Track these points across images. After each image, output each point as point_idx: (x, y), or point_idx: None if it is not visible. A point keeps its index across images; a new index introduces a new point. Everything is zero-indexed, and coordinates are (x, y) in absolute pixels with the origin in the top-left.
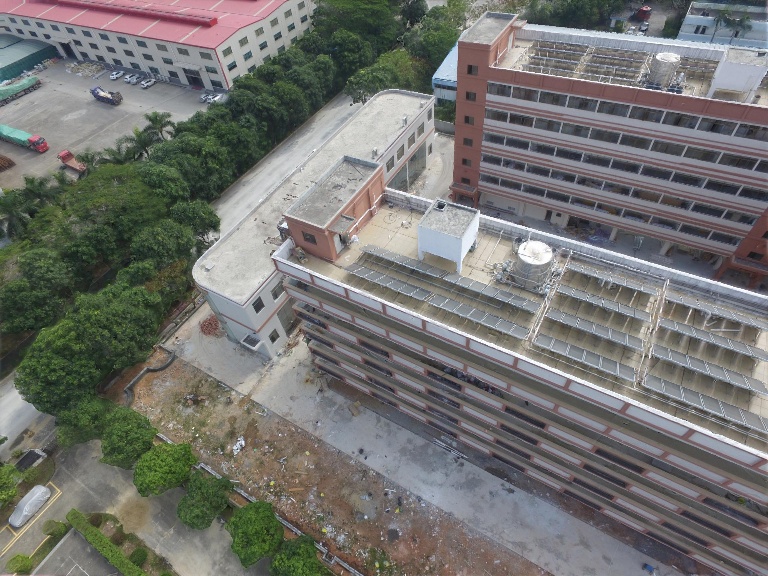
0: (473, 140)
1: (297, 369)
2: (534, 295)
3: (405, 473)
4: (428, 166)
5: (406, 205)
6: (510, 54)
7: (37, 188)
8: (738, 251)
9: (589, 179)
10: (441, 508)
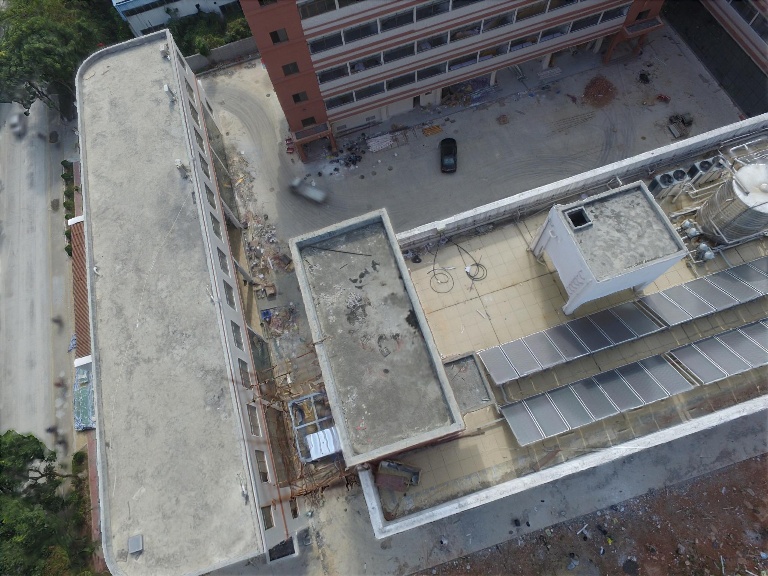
0: (297, 62)
1: (351, 508)
2: (757, 242)
3: (576, 498)
4: (221, 131)
5: (438, 240)
6: None
7: None
8: (627, 20)
9: (464, 28)
10: (638, 495)
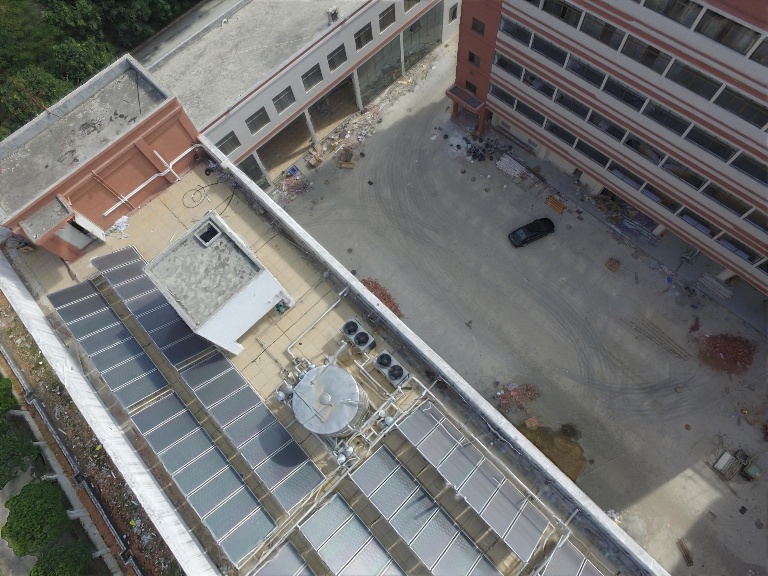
0: (486, 25)
1: None
2: (330, 448)
3: None
4: (447, 39)
5: (229, 177)
6: None
7: None
8: None
9: (645, 144)
10: None
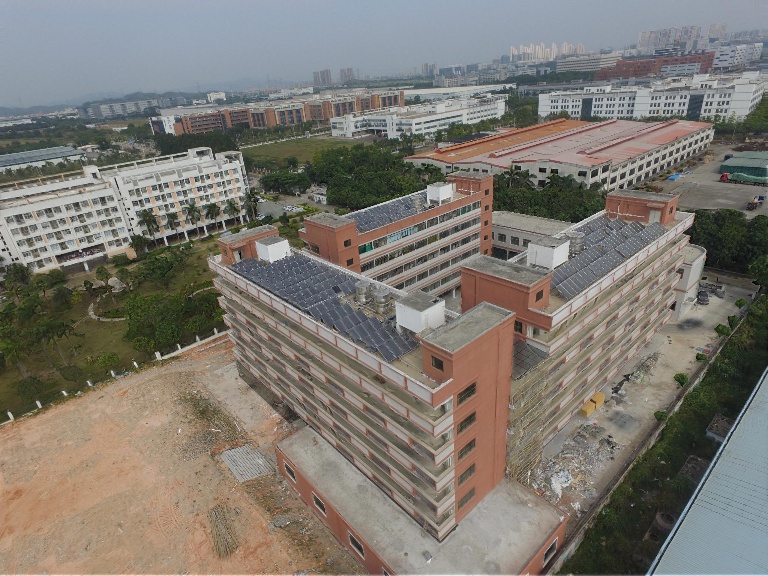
0: None
1: None
2: None
3: None
4: None
5: None
6: (645, 223)
7: (568, 180)
8: None
9: None
10: None
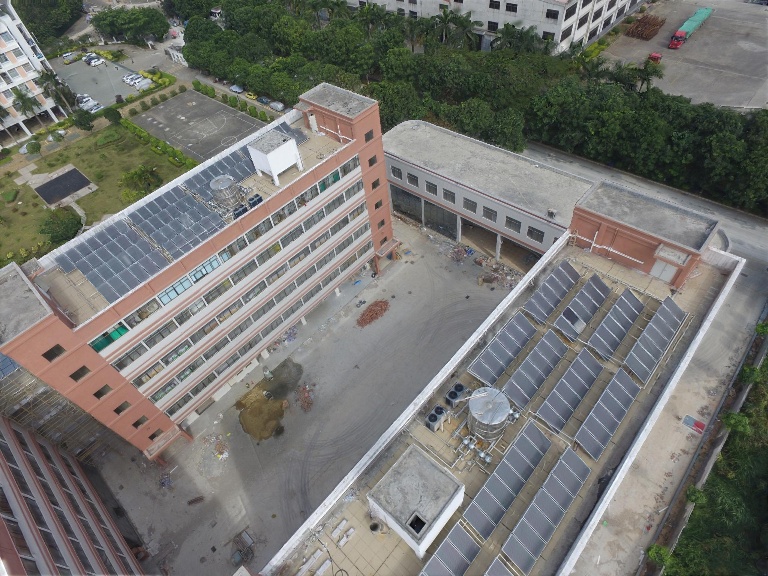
0: None
1: None
2: None
3: None
4: None
5: None
6: (642, 276)
7: (528, 37)
8: None
9: None
10: None
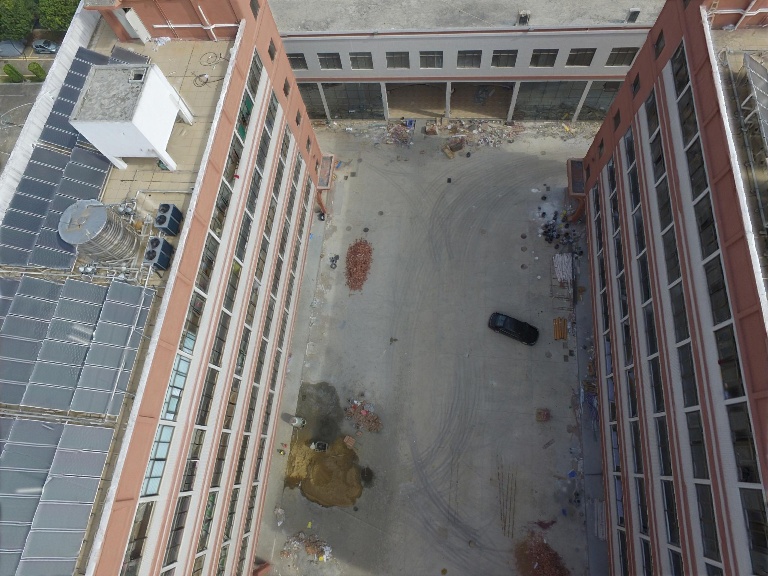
0: (621, 123)
1: None
2: None
3: None
4: None
5: None
6: None
7: None
8: None
9: None
10: None
